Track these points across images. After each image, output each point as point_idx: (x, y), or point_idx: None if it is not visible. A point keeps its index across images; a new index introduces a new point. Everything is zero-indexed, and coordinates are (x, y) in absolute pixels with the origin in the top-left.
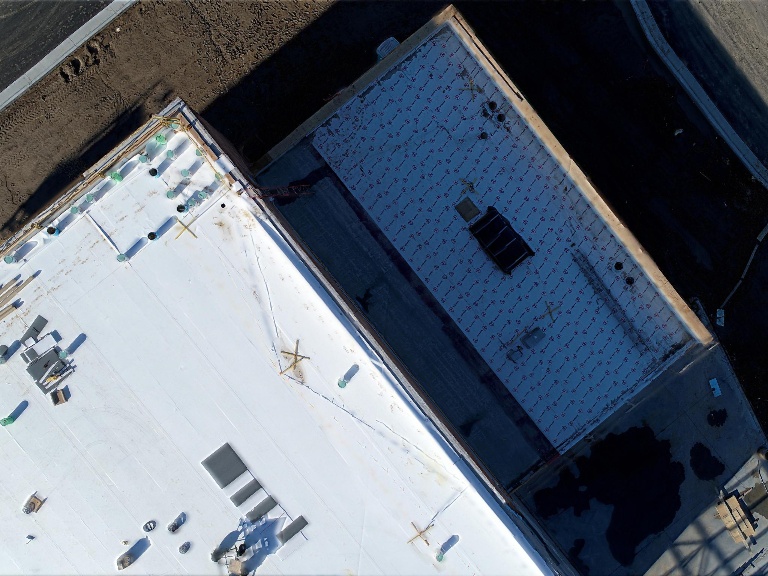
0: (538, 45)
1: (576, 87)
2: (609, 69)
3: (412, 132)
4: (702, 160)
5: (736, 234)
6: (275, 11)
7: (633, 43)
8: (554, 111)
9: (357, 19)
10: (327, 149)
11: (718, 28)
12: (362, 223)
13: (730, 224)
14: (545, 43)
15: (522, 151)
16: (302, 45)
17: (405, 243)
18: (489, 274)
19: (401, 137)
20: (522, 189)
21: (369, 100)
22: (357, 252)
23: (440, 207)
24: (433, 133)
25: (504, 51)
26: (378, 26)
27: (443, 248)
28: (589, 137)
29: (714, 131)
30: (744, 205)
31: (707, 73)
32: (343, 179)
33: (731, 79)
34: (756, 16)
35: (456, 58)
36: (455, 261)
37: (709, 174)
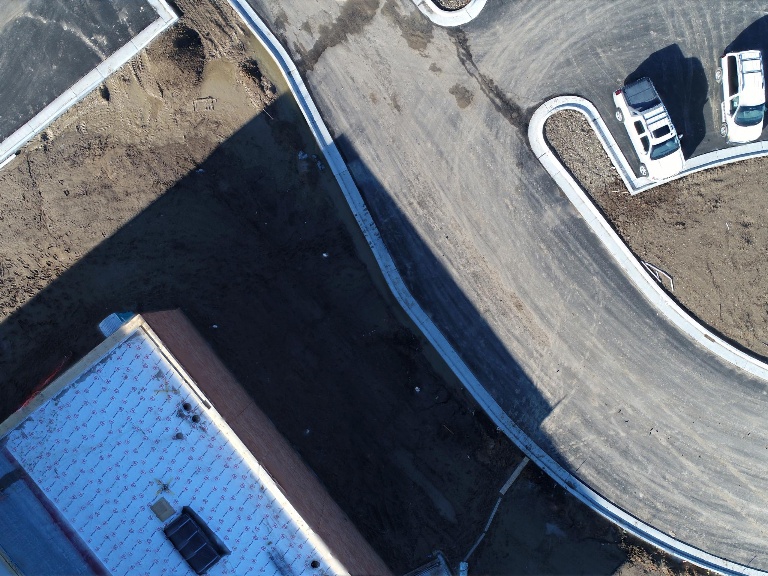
0: (280, 300)
1: (319, 342)
2: (352, 323)
3: (107, 433)
4: (445, 413)
5: (479, 487)
6: (17, 269)
7: (377, 296)
8: (297, 365)
9: (98, 277)
10: (21, 452)
11: (462, 281)
12: (57, 524)
13: (474, 477)
14: (287, 298)
15: (218, 451)
16: (44, 302)
17: (100, 544)
18: (185, 573)
19: (96, 438)
20: (218, 488)
21: (64, 402)
22: (52, 553)
23: (135, 507)
24: (128, 434)
25: (246, 307)
26: (119, 284)
27: (139, 548)
28: (332, 391)
29: (460, 382)
30: (487, 458)
31: (451, 325)
32: (37, 481)
33: (476, 331)
34: (500, 268)
35: (151, 359)
36: (151, 561)
37: (452, 427)
